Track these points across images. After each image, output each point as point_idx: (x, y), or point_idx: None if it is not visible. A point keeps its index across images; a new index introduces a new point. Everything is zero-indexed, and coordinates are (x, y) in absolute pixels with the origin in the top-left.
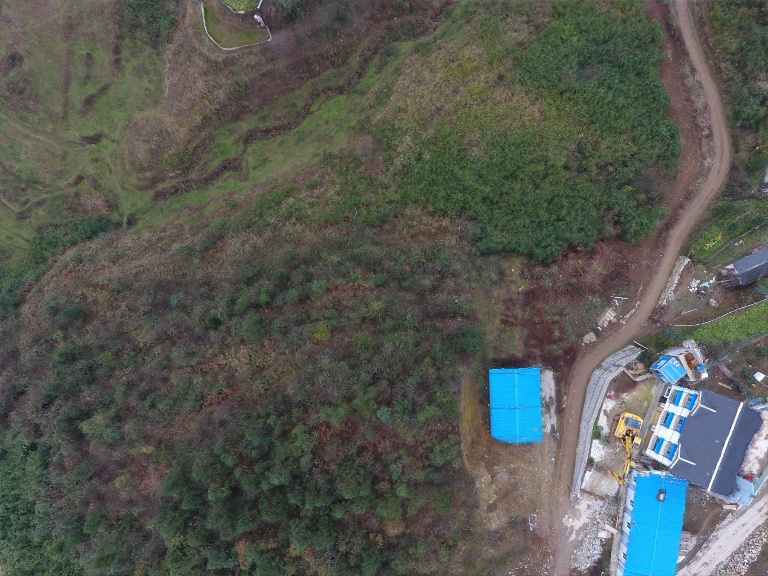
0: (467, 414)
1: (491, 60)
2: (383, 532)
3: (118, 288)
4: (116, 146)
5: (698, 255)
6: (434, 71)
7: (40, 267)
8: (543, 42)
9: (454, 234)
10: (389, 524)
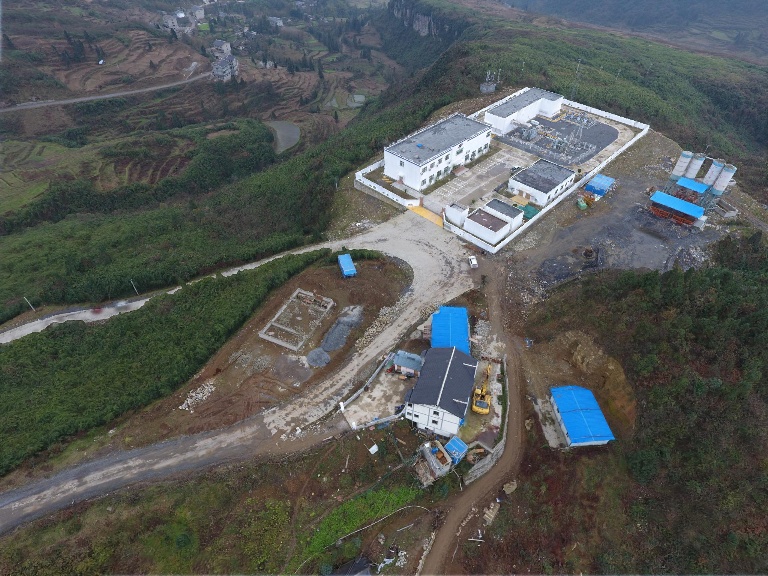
0: (617, 404)
1: None
2: None
3: None
4: None
5: None
6: None
7: None
8: None
9: None
10: None
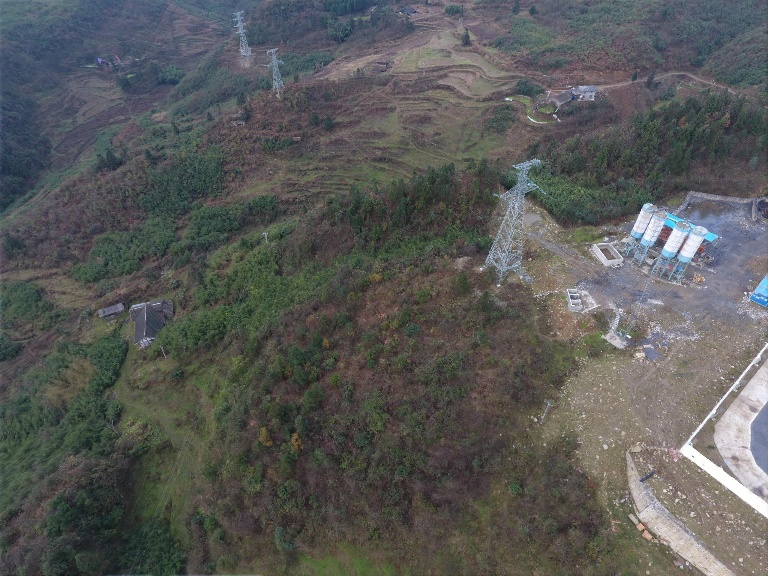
0: None
1: None
2: None
3: None
4: None
5: None
6: None
7: None
8: None
9: None
10: None
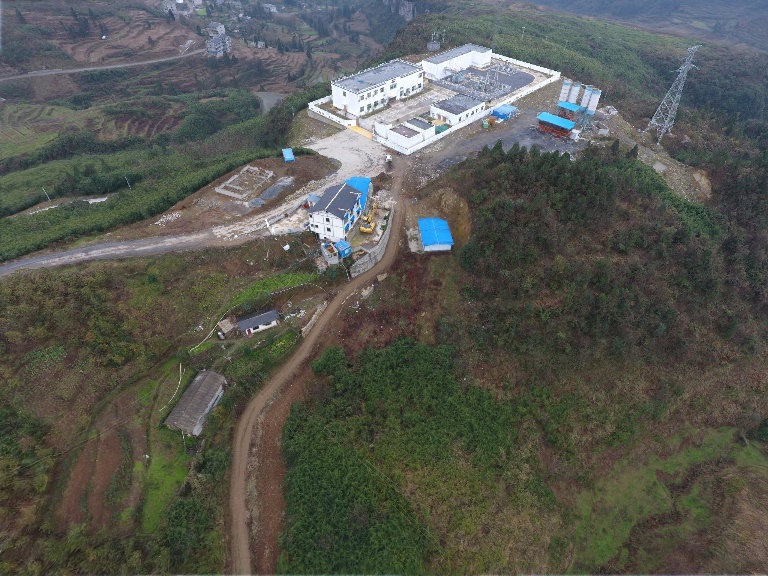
0: (462, 228)
1: (454, 572)
2: None
3: None
4: None
5: (293, 336)
6: (511, 572)
7: None
8: None
9: None
10: None
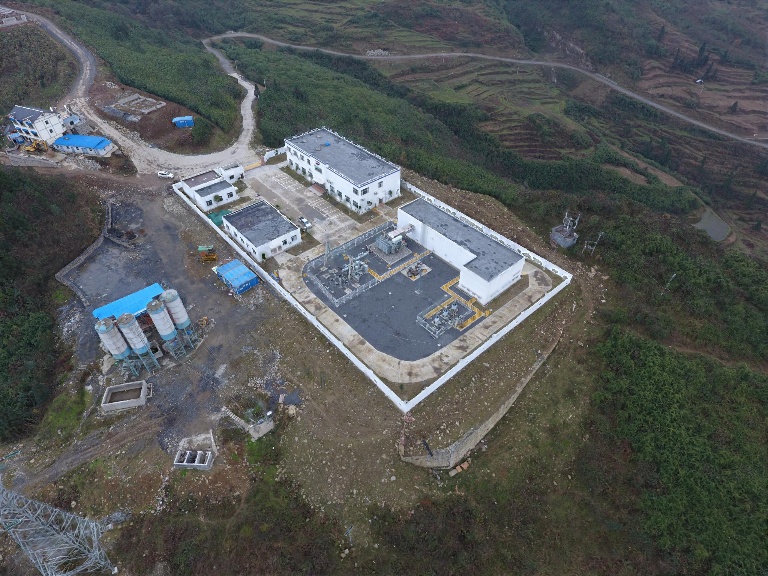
0: None
1: None
2: None
3: None
4: None
5: None
6: None
7: None
8: None
9: None
10: None
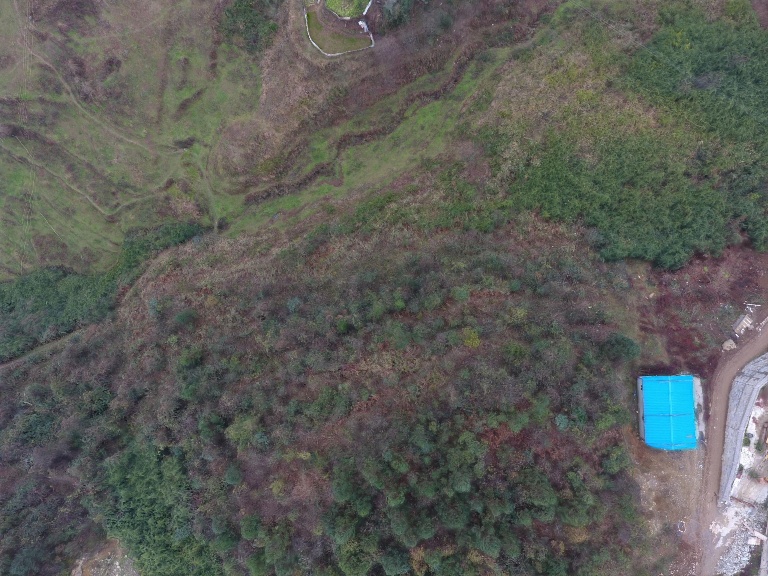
0: None
1: (597, 67)
2: (565, 539)
3: (225, 292)
4: (208, 150)
5: None
6: (536, 77)
7: (133, 271)
8: (653, 49)
9: (572, 240)
10: (575, 531)
